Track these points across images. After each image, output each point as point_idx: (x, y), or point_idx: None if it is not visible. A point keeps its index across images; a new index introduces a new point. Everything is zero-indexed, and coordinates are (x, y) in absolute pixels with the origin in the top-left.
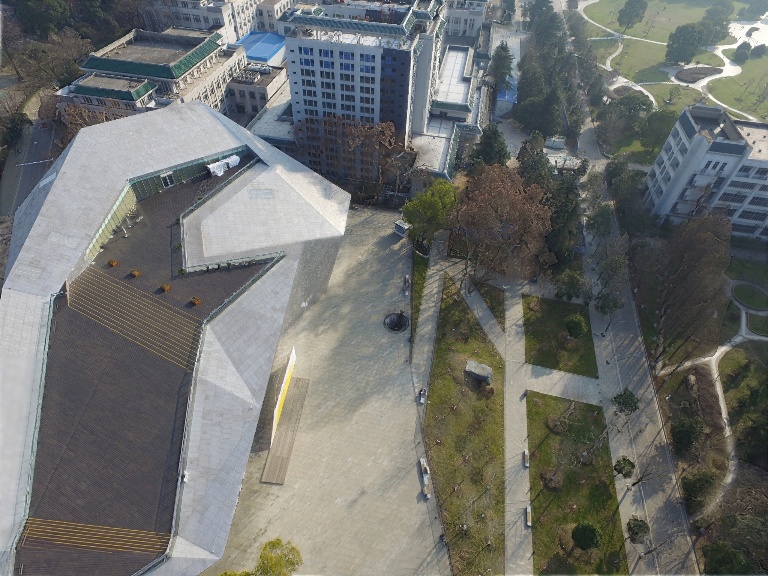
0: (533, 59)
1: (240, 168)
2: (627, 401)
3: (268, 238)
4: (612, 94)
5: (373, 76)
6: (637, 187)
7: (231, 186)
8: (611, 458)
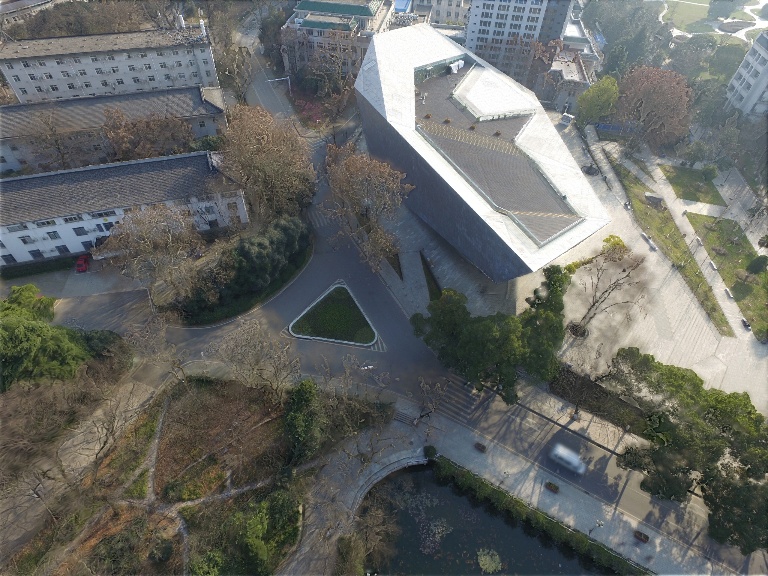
0: (612, 11)
1: (466, 69)
2: (760, 207)
3: None
4: (676, 39)
5: (540, 7)
6: (722, 96)
7: (469, 78)
8: (751, 244)
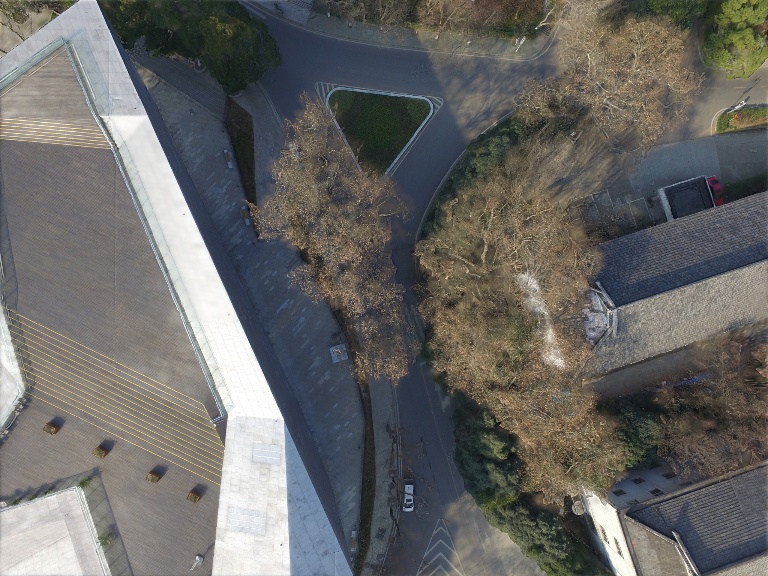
0: None
1: None
2: None
3: None
4: None
5: None
6: None
7: None
8: None
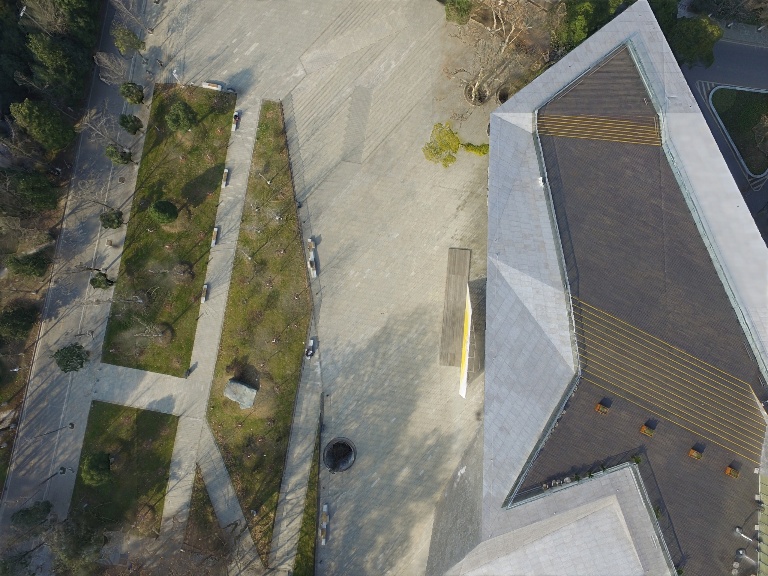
0: None
1: None
2: (69, 353)
3: (536, 561)
4: None
5: None
6: None
7: None
8: None
